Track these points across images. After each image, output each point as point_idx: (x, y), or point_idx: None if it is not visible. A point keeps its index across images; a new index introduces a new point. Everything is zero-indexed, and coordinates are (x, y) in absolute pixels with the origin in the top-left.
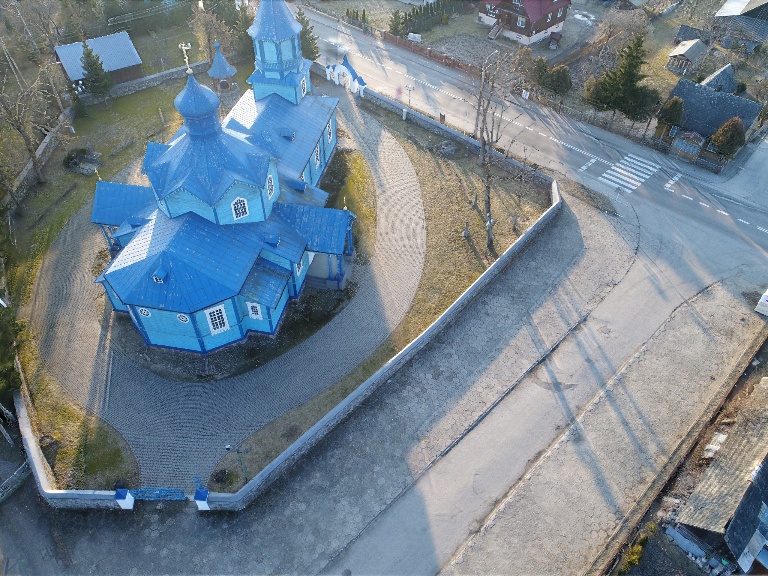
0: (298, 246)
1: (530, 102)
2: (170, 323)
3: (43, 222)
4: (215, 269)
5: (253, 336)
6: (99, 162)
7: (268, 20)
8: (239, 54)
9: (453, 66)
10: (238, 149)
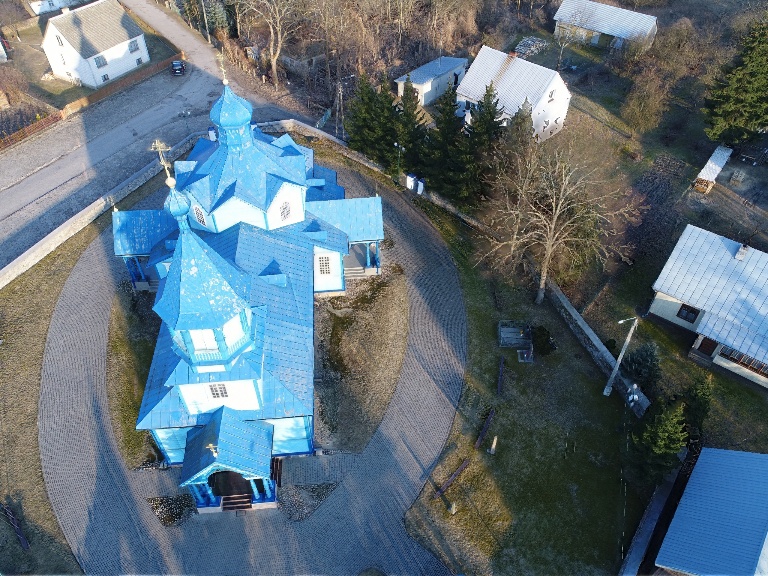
0: None
1: None
2: None
3: None
4: None
5: None
6: None
7: None
8: None
9: None
10: None
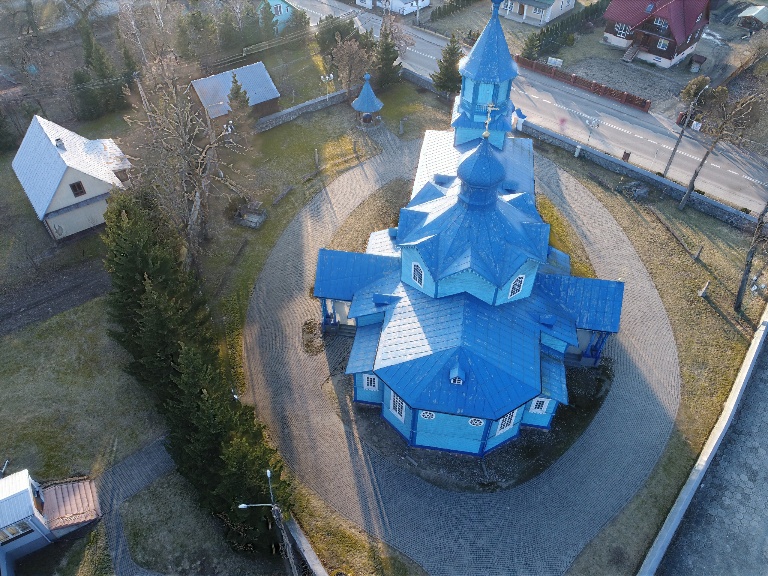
0: (569, 324)
1: (702, 134)
2: (454, 426)
3: (226, 287)
4: (511, 363)
5: (522, 430)
6: (265, 213)
7: (490, 59)
8: (372, 83)
9: (604, 94)
10: (513, 217)
